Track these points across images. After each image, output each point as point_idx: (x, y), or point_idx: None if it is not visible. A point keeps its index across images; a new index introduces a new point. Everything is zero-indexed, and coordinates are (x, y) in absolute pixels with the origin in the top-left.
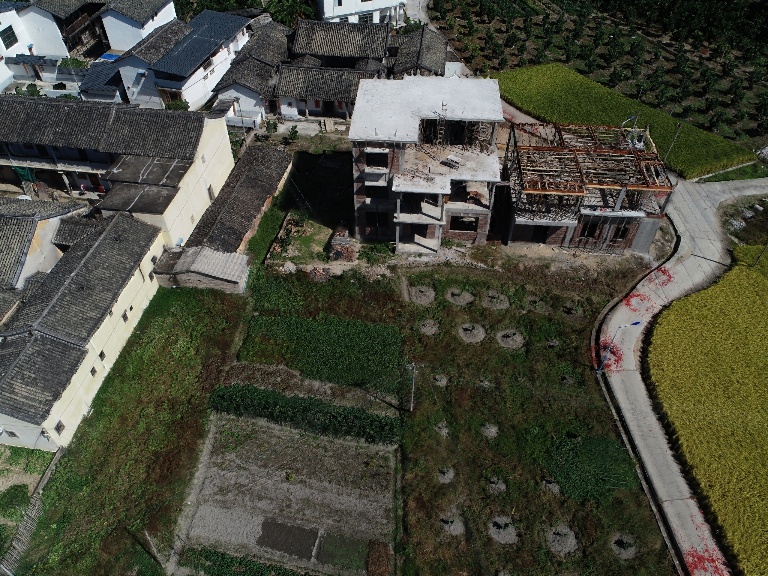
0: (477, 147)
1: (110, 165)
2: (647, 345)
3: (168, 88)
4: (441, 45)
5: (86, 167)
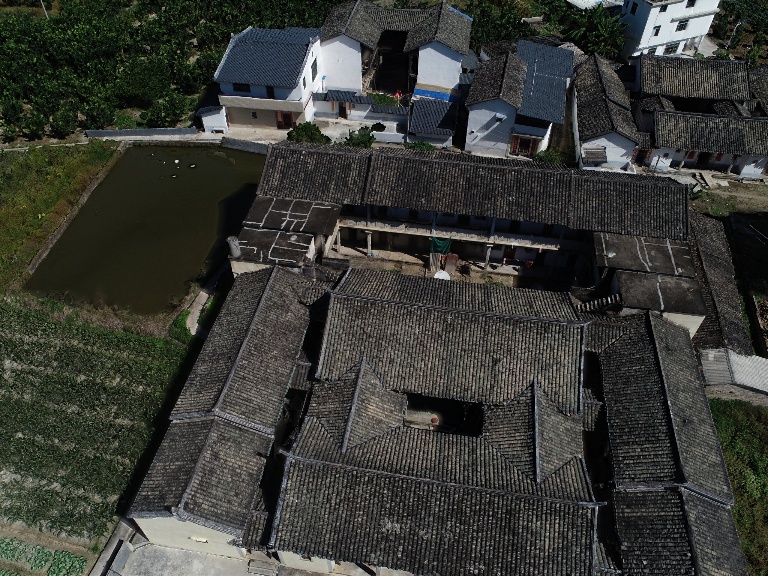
0: None
1: (561, 240)
2: None
3: (528, 135)
4: None
5: (526, 241)
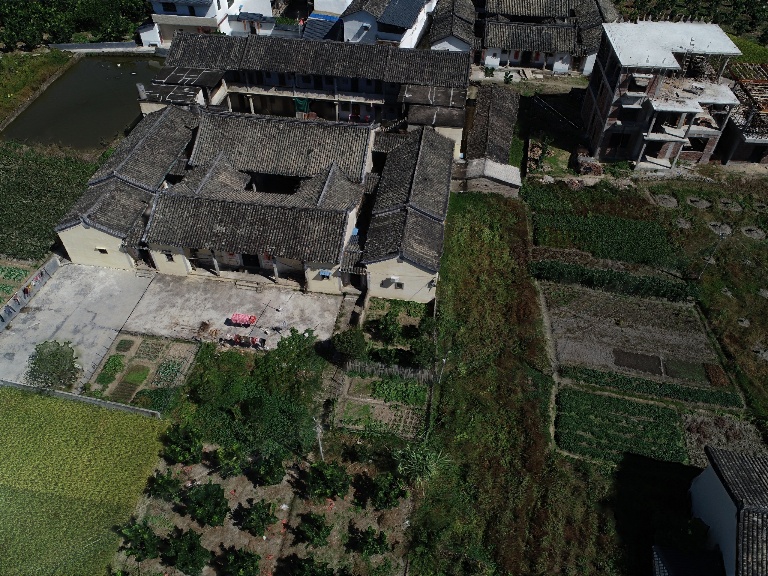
0: (707, 79)
1: (384, 95)
2: None
3: (388, 40)
4: (612, 8)
5: (361, 98)
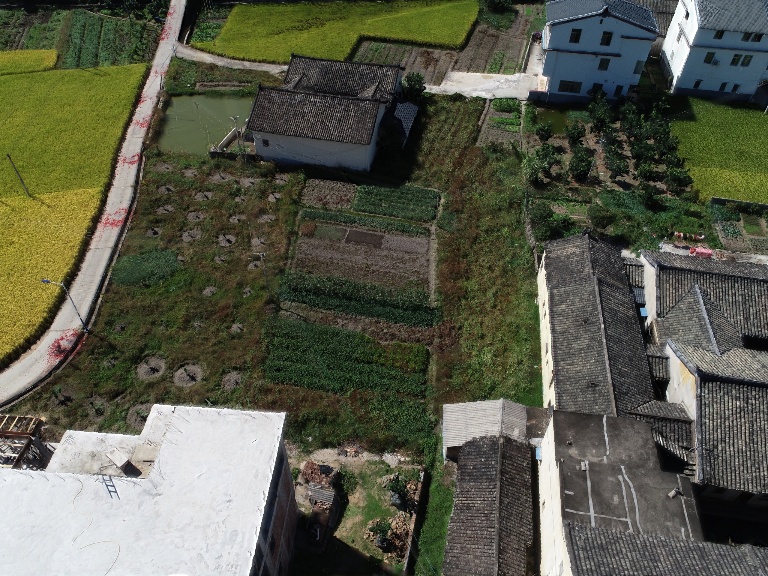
0: None
1: None
2: (18, 353)
3: None
4: None
5: None
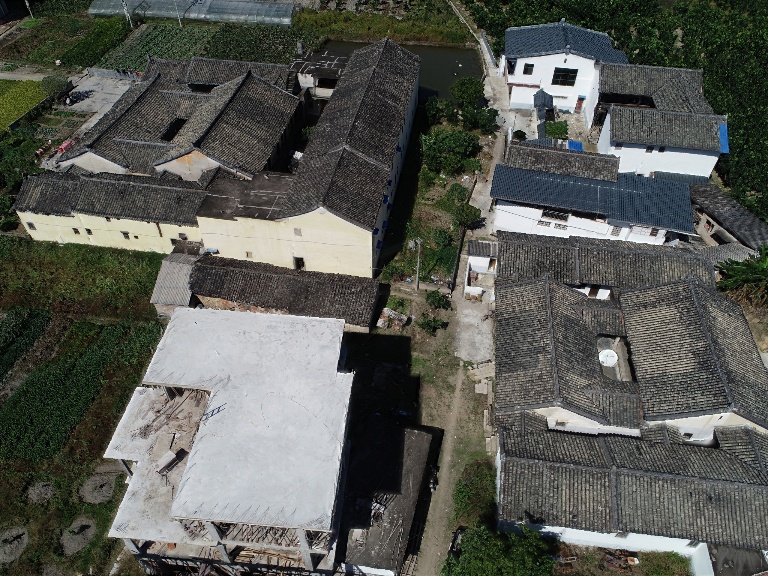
0: None
1: None
2: None
3: None
4: (760, 533)
5: None
